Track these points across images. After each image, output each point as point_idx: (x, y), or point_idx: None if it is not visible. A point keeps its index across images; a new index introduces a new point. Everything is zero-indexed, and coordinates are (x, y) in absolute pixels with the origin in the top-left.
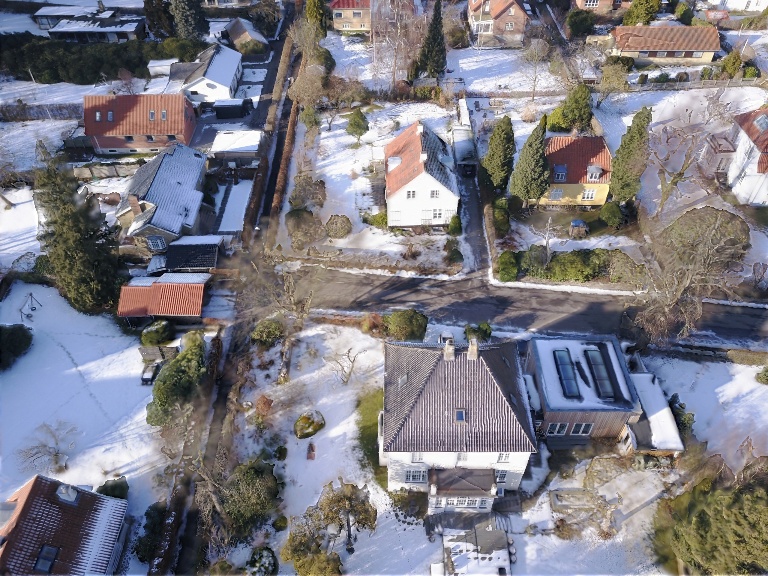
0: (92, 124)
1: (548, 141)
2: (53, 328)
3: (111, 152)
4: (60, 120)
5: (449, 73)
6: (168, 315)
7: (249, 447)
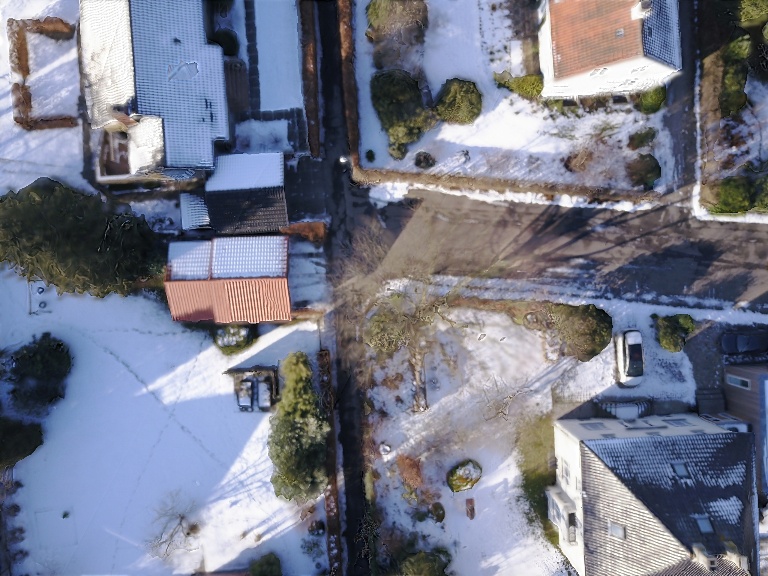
0: None
1: None
2: (85, 323)
3: None
4: None
5: None
6: None
7: (398, 503)
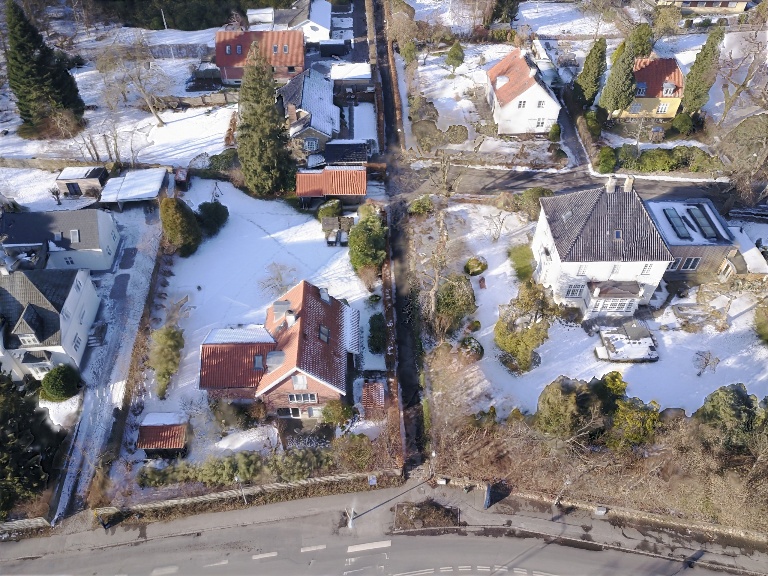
0: (223, 56)
1: None
2: (239, 209)
3: (236, 83)
4: (179, 59)
5: (516, 21)
6: (339, 195)
7: None
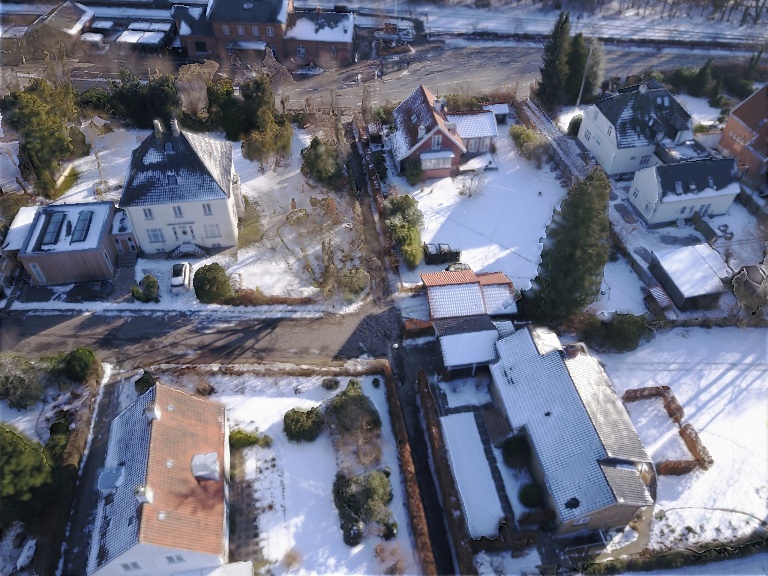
0: None
1: None
2: None
3: None
4: None
5: None
6: None
7: (339, 205)
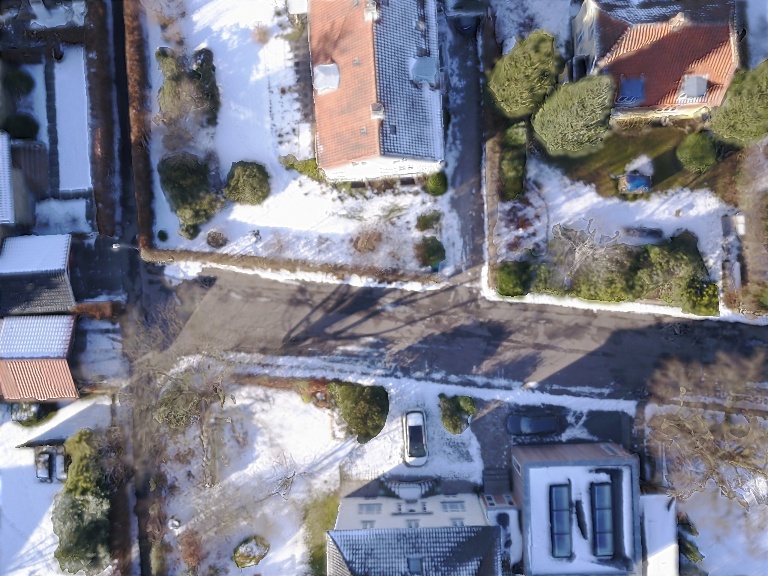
0: None
1: (621, 32)
2: None
3: None
4: None
5: None
6: None
7: None
